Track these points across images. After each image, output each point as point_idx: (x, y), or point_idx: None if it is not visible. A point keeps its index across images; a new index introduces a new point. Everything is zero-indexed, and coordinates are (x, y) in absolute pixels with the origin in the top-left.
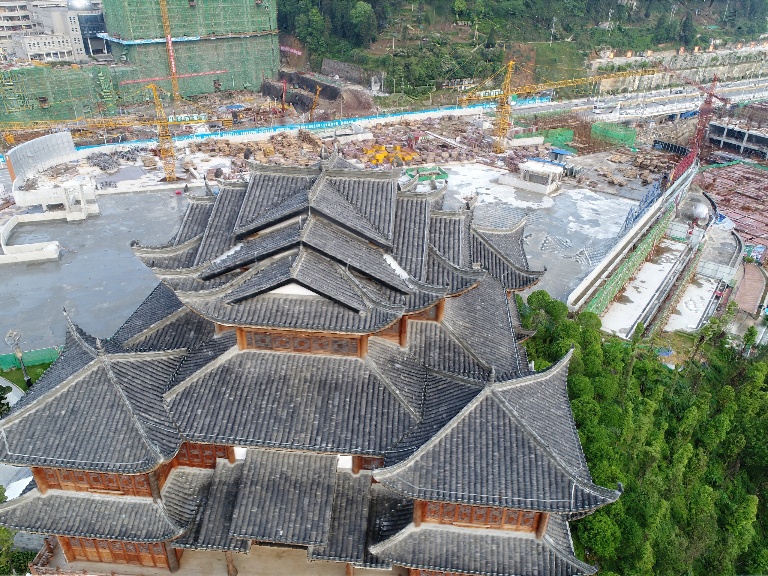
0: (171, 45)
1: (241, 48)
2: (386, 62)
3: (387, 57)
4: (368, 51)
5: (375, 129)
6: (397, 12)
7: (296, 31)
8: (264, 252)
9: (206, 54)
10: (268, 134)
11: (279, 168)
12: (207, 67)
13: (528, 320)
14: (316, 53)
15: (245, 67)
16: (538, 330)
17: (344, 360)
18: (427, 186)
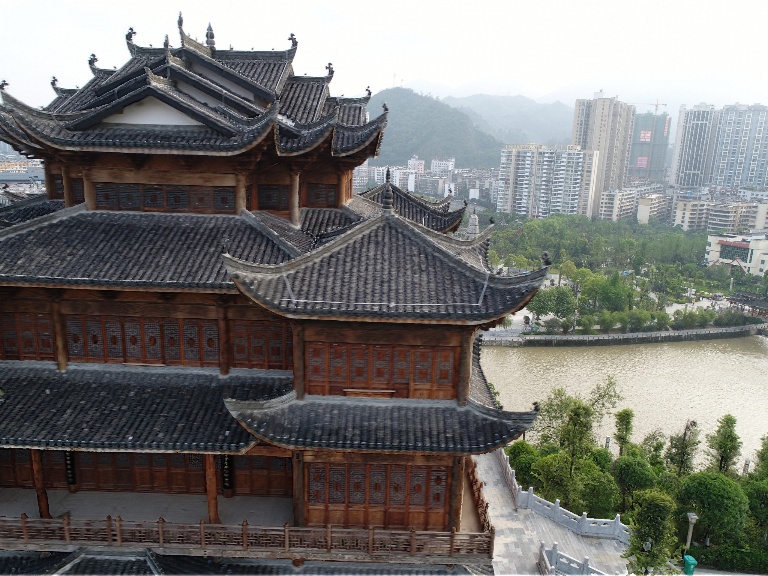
0: None
1: None
2: None
3: None
4: None
5: None
6: None
7: None
8: (324, 100)
9: None
10: None
11: (195, 44)
12: None
13: None
14: None
15: None
16: None
17: (353, 201)
18: None
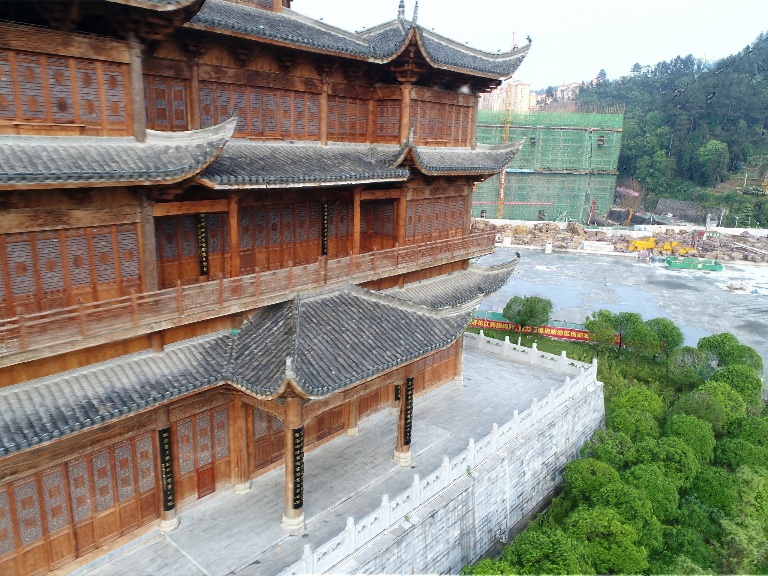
0: (504, 174)
1: (574, 184)
2: (730, 198)
3: (732, 193)
4: (712, 189)
5: (664, 234)
6: (759, 151)
7: (636, 172)
8: None
9: (537, 186)
10: (533, 222)
11: None
12: (535, 198)
13: (672, 356)
14: (653, 193)
15: (574, 202)
16: (684, 372)
17: None
18: (684, 272)
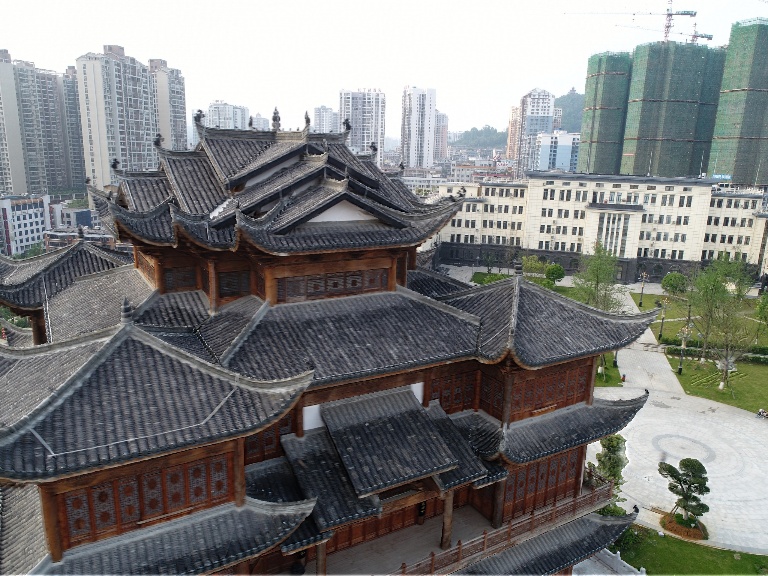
0: None
1: None
2: None
3: None
4: None
5: None
6: None
7: None
8: None
9: None
10: None
11: (319, 136)
12: None
13: None
14: None
15: None
16: None
17: None
18: None
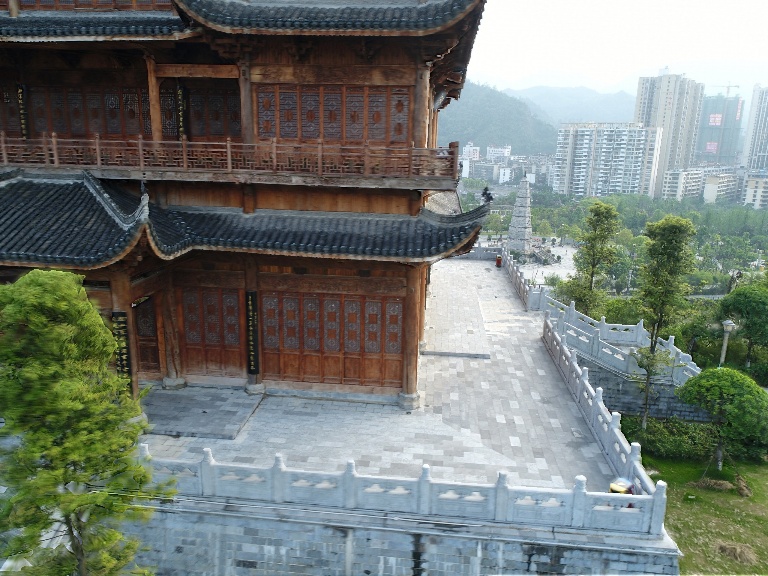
0: None
1: None
2: None
3: None
4: None
5: None
6: None
7: None
8: None
9: None
10: None
11: None
12: None
13: None
14: None
15: None
16: None
17: None
18: None
